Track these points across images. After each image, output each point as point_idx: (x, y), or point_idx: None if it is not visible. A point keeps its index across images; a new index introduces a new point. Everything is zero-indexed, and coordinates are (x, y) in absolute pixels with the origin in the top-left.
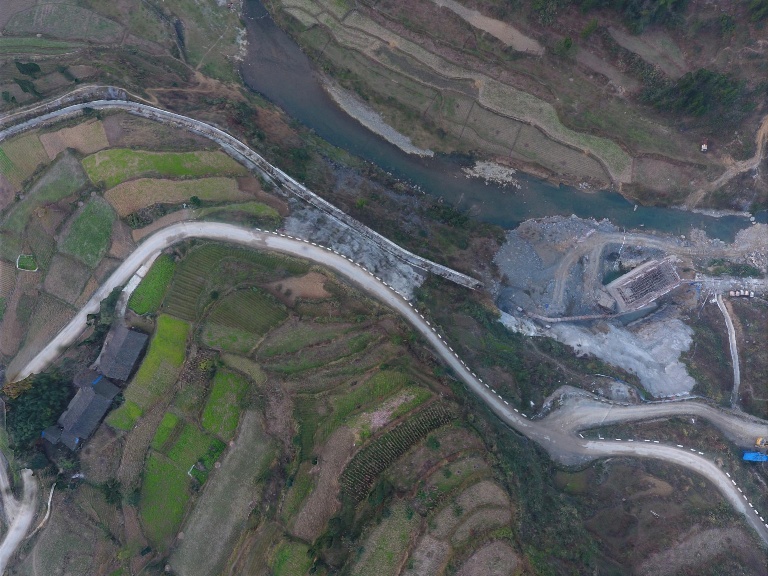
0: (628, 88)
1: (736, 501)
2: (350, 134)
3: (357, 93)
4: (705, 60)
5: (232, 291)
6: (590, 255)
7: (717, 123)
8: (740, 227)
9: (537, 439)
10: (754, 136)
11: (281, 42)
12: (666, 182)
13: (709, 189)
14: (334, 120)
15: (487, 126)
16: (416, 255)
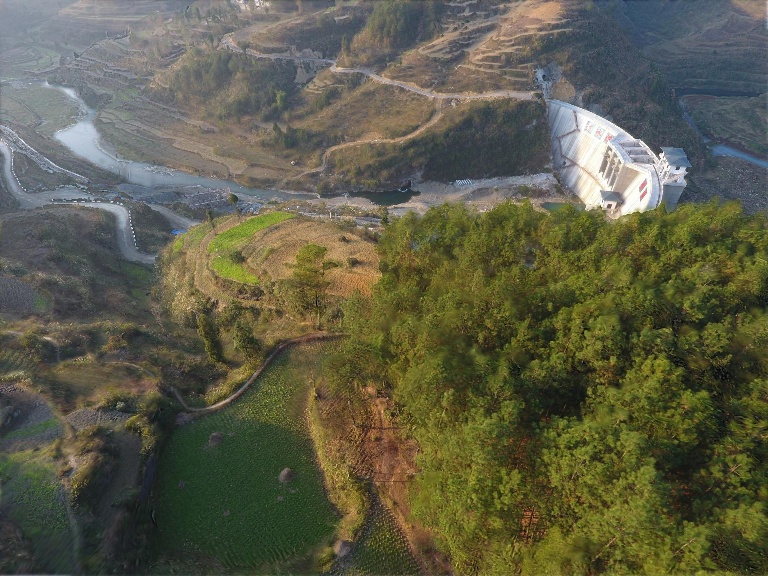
0: (256, 140)
1: (122, 223)
2: (92, 154)
3: None
4: (295, 127)
5: None
6: (190, 195)
7: (299, 151)
8: (308, 199)
9: None
10: (320, 156)
11: (89, 128)
12: (264, 175)
13: (290, 179)
14: (89, 149)
15: None
16: (62, 168)
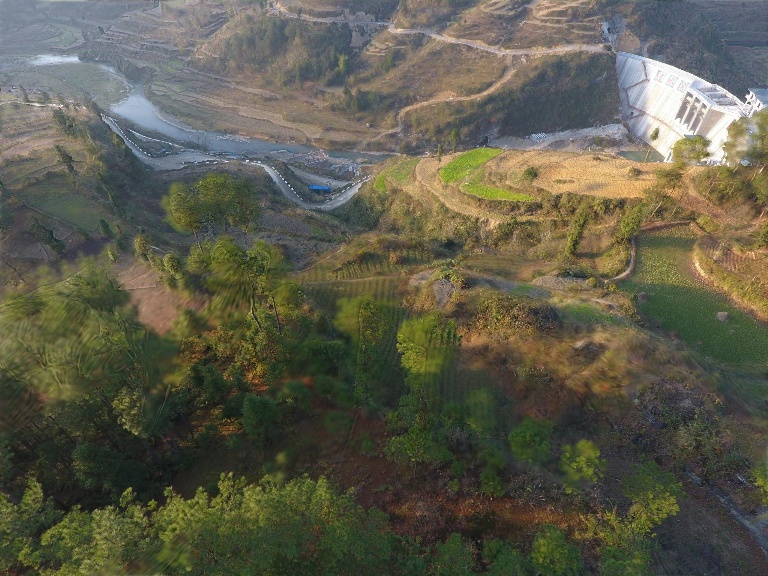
0: (324, 105)
1: (273, 178)
2: (158, 126)
3: (172, 114)
4: (363, 90)
5: (7, 106)
6: None
7: (372, 113)
8: None
9: (151, 164)
10: (395, 117)
11: (143, 101)
12: (342, 138)
13: (370, 141)
14: (152, 122)
15: (239, 121)
16: None
